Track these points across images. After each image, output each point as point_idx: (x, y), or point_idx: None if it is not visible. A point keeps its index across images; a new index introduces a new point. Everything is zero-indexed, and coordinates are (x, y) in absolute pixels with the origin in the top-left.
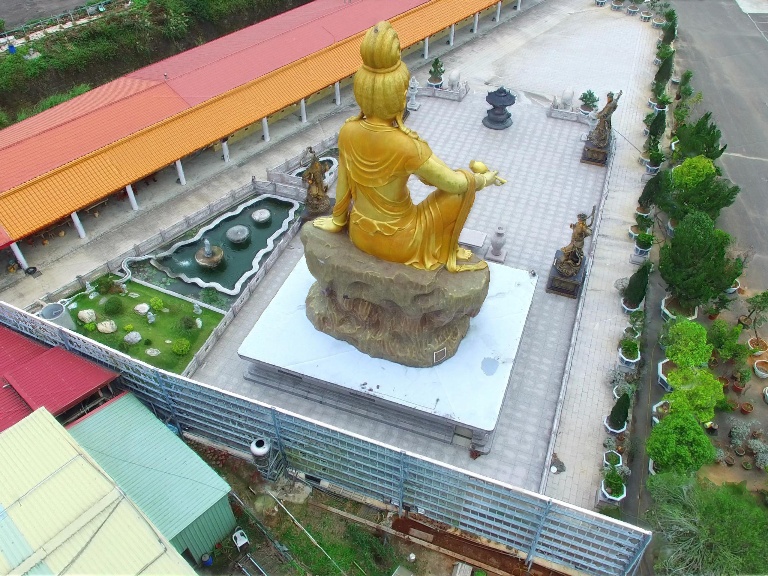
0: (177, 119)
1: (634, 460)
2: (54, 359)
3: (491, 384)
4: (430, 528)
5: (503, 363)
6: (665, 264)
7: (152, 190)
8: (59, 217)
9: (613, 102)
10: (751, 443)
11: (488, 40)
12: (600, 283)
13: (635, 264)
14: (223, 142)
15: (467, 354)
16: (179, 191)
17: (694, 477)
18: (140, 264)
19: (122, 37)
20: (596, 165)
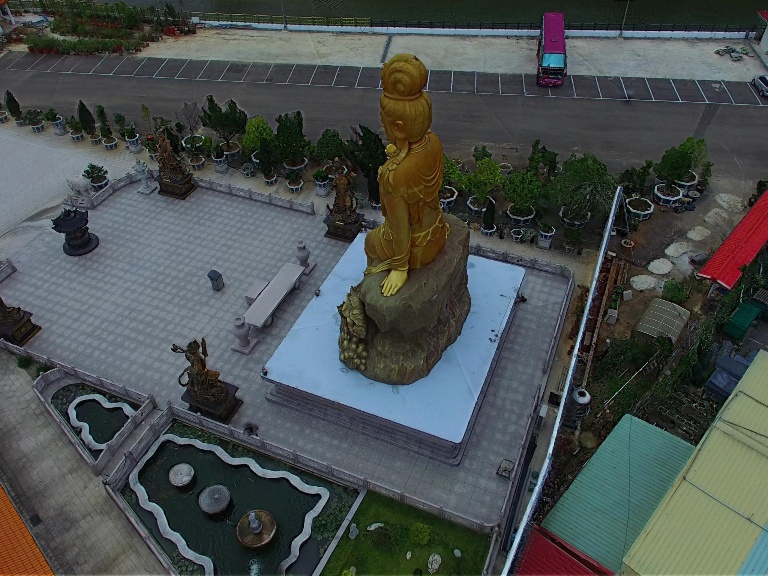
0: None
1: None
2: None
3: (483, 266)
4: None
5: None
6: None
7: None
8: None
9: None
10: None
11: None
12: None
13: (328, 196)
14: None
15: None
16: None
17: None
18: None
19: None
20: (193, 192)
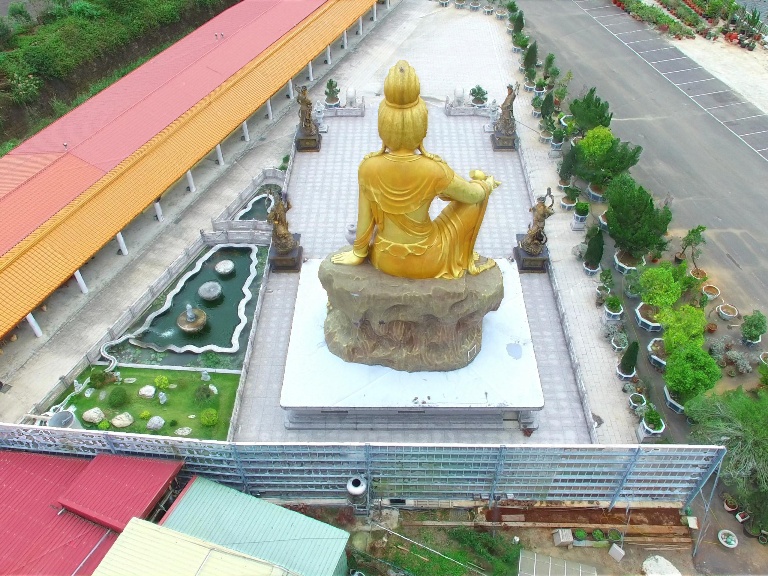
0: (105, 189)
1: (650, 396)
2: (104, 468)
3: (524, 366)
4: (519, 509)
5: (524, 345)
6: (614, 225)
7: (94, 268)
8: (18, 320)
9: (513, 93)
10: (730, 354)
11: (361, 53)
12: (557, 254)
13: (577, 231)
14: (157, 202)
15: (491, 346)
16: (124, 262)
17: None
18: (118, 347)
19: None
20: (508, 151)
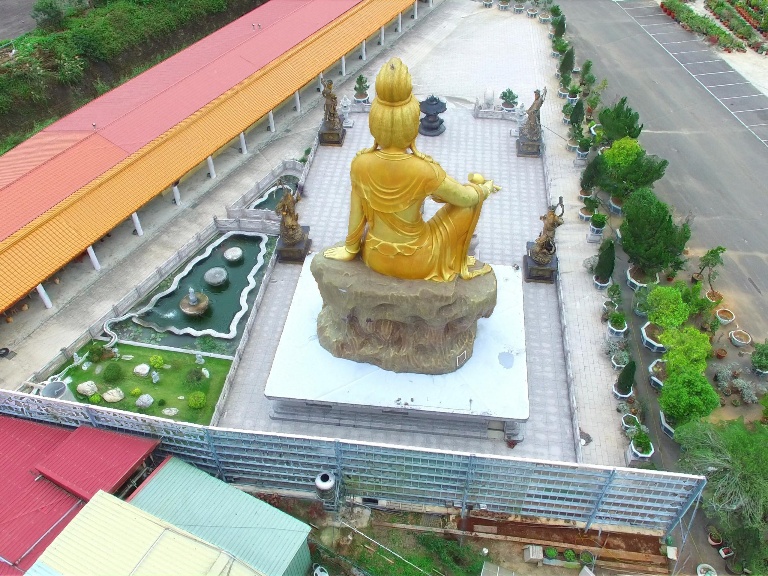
0: (125, 169)
1: (646, 418)
2: (84, 439)
3: (513, 376)
4: (492, 521)
5: (517, 355)
6: (627, 239)
7: (109, 246)
8: (27, 291)
9: (540, 98)
10: (735, 383)
11: (397, 51)
12: (569, 265)
13: (593, 243)
14: (175, 186)
15: (483, 353)
16: (138, 243)
17: (701, 422)
18: (122, 324)
19: (14, 89)
20: (532, 157)
